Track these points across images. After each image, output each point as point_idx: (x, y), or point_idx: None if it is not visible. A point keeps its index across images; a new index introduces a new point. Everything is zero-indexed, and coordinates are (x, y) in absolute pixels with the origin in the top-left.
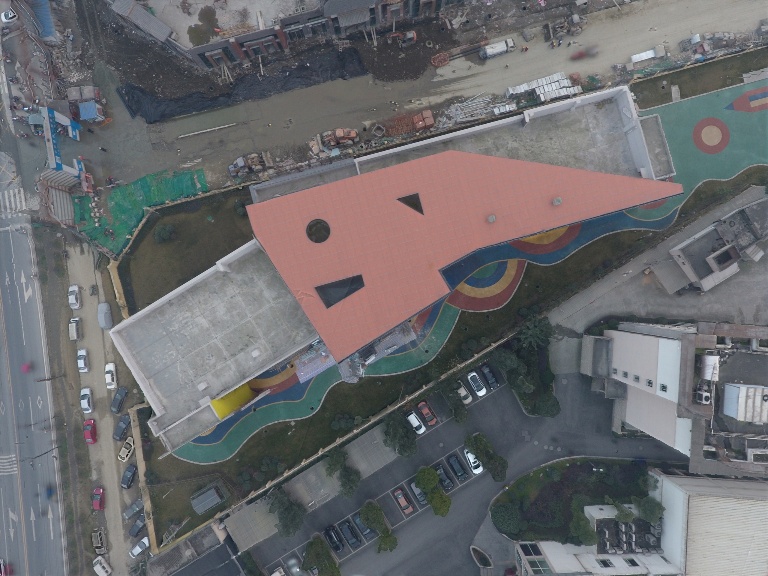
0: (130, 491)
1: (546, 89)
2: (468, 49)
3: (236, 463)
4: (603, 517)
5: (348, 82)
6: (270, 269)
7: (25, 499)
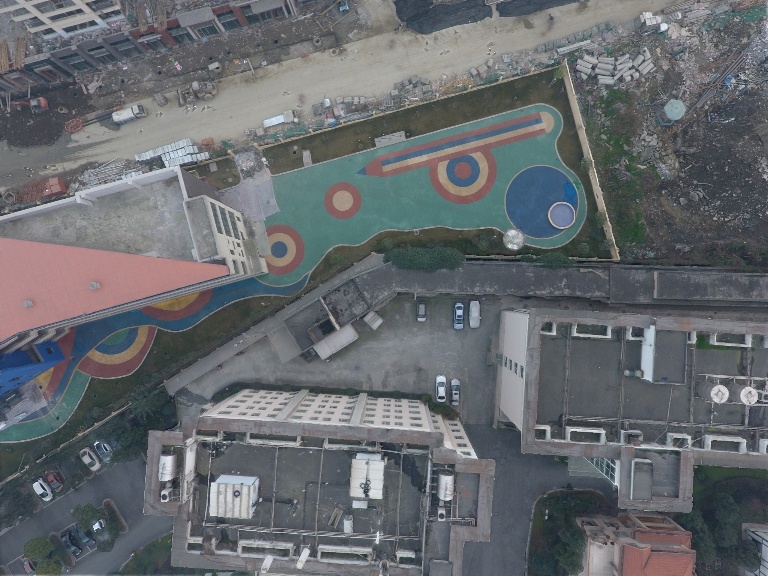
0: None
1: (172, 156)
2: (102, 114)
3: None
4: None
5: None
6: None
7: None
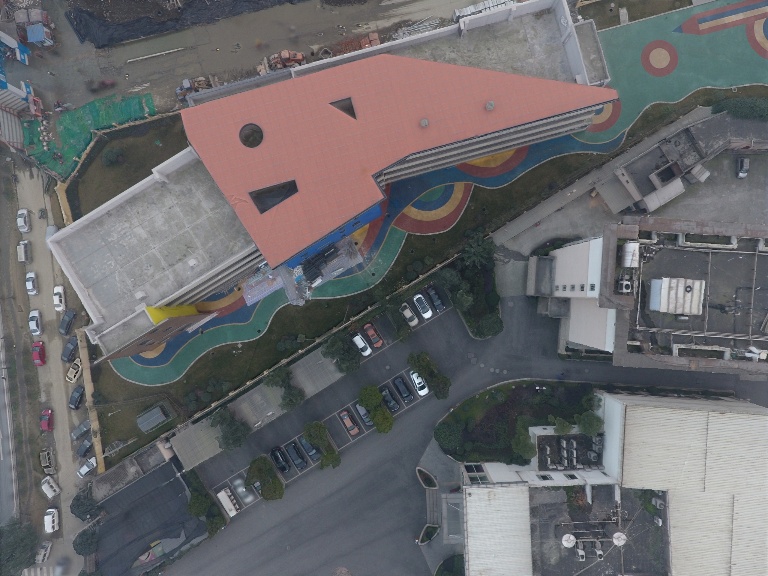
0: (79, 412)
1: None
2: None
3: (183, 385)
4: (545, 434)
5: (296, 6)
6: (208, 180)
7: None
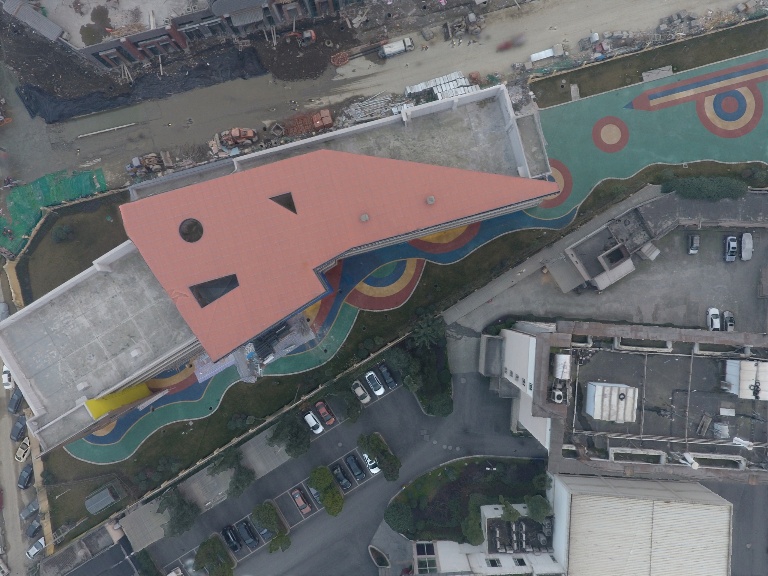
0: (28, 491)
1: (444, 88)
2: (368, 48)
3: (134, 463)
4: (494, 516)
5: (248, 81)
6: None
7: None
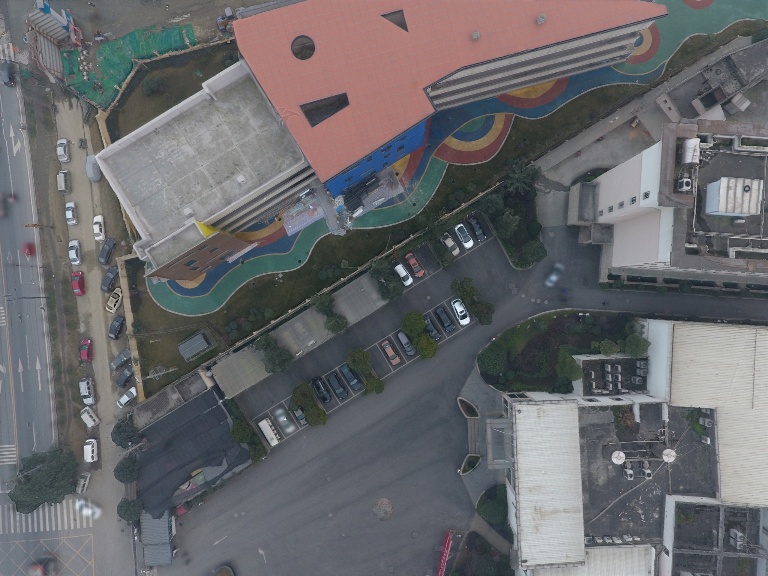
0: (118, 343)
1: None
2: None
3: (224, 315)
4: (589, 358)
5: None
6: (256, 98)
7: (13, 351)
